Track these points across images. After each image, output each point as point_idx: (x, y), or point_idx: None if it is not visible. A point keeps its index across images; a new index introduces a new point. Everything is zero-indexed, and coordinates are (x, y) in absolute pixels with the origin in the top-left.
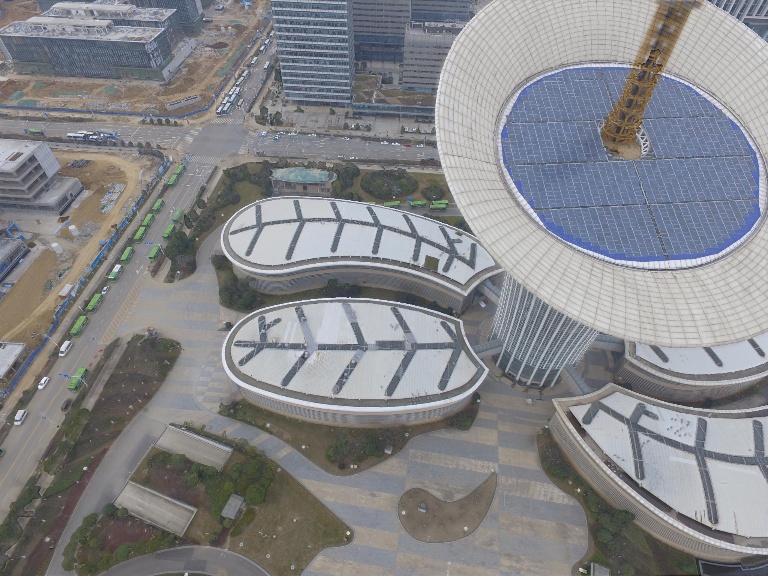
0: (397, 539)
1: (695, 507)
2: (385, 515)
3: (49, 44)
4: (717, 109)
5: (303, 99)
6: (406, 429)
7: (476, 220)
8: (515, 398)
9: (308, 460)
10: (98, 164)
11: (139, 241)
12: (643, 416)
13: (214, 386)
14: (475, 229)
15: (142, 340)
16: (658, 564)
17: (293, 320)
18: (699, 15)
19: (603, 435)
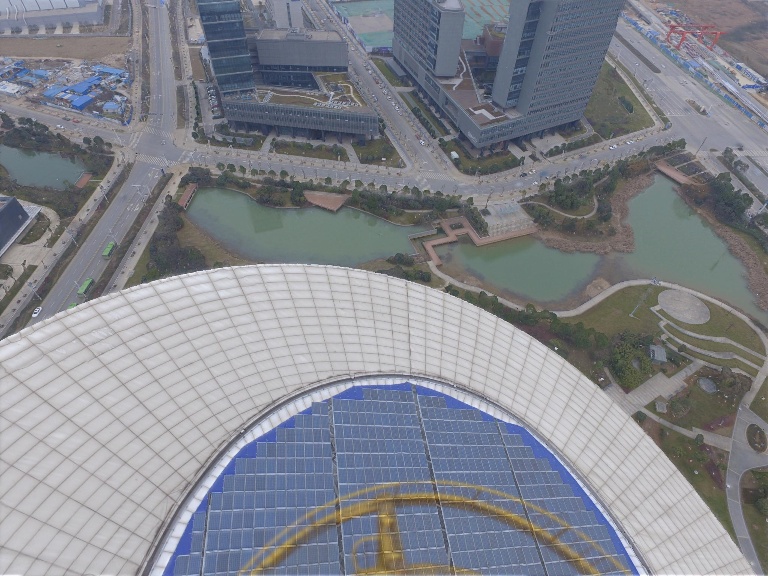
0: None
1: None
2: None
3: None
4: (313, 411)
5: None
6: None
7: None
8: None
9: None
10: None
11: None
12: None
13: None
14: None
15: None
16: None
17: None
18: (57, 371)
19: None
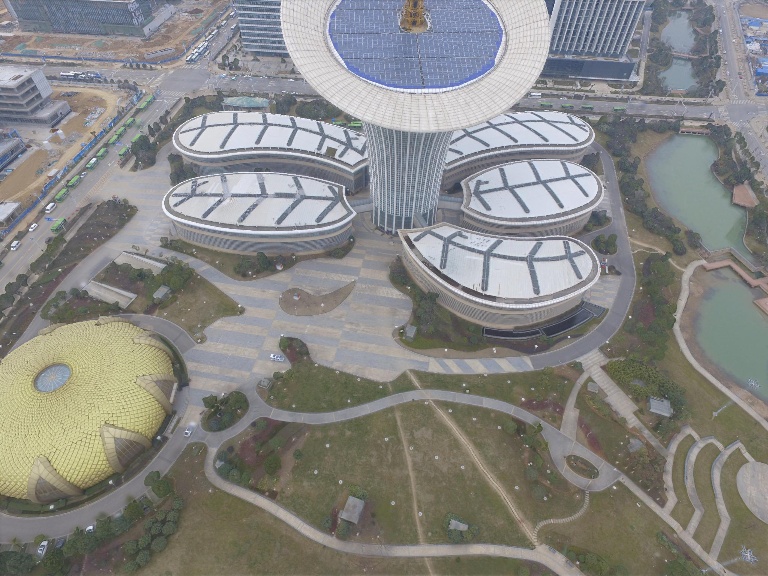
0: (275, 313)
1: (474, 282)
2: (270, 301)
3: (48, 4)
4: (484, 4)
5: (259, 50)
6: (296, 257)
7: (298, 59)
8: (382, 242)
9: (221, 272)
10: (84, 95)
11: (112, 145)
12: (457, 237)
13: (159, 231)
14: (296, 64)
15: None
16: (454, 328)
17: (217, 181)
18: None
19: (425, 246)
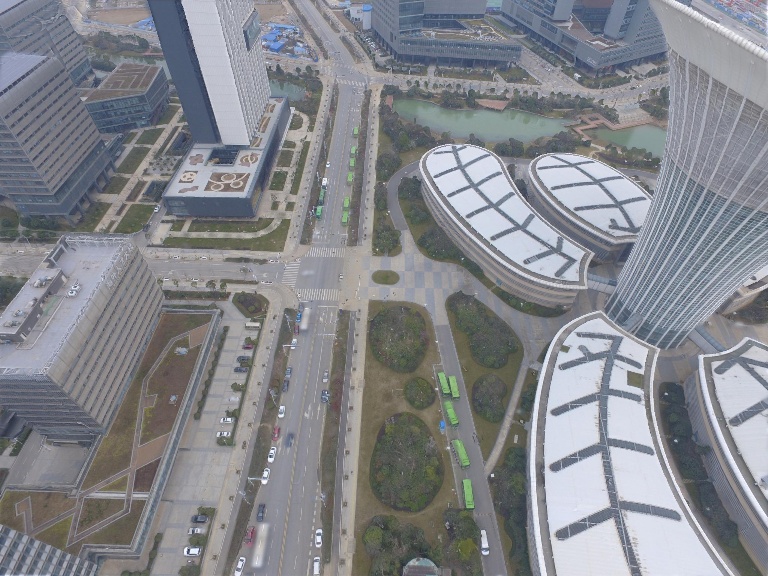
0: None
1: None
2: None
3: None
4: None
5: None
6: None
7: None
8: None
9: None
10: None
11: None
12: None
13: None
14: None
15: None
16: None
17: None
18: None
19: (760, 270)
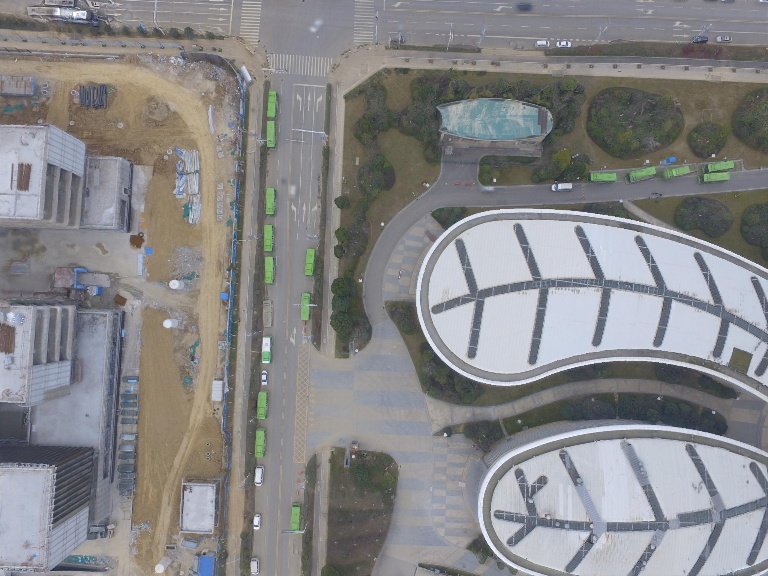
0: None
1: None
2: None
3: None
4: None
5: None
6: None
7: None
8: None
9: None
10: (125, 96)
11: (272, 283)
12: None
13: (452, 515)
14: None
15: (346, 457)
16: None
17: (564, 481)
18: None
19: None
